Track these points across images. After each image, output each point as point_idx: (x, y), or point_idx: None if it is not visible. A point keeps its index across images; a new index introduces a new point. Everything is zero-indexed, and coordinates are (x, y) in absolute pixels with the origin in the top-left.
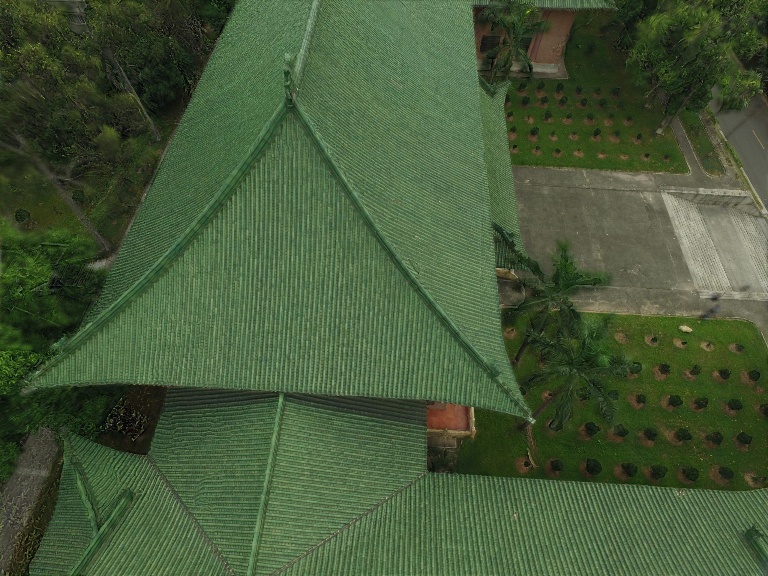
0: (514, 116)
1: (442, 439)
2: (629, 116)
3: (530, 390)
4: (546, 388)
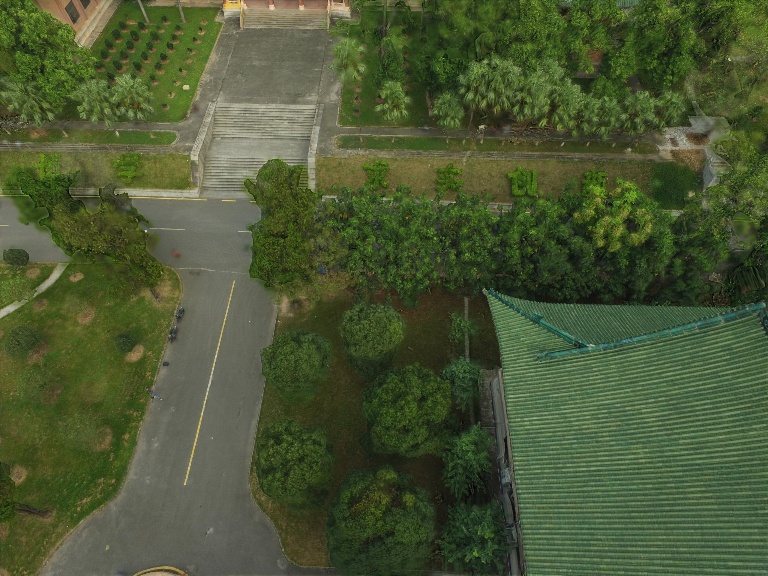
0: (408, 39)
1: (153, 2)
2: (406, 91)
3: (167, 26)
4: (166, 31)
